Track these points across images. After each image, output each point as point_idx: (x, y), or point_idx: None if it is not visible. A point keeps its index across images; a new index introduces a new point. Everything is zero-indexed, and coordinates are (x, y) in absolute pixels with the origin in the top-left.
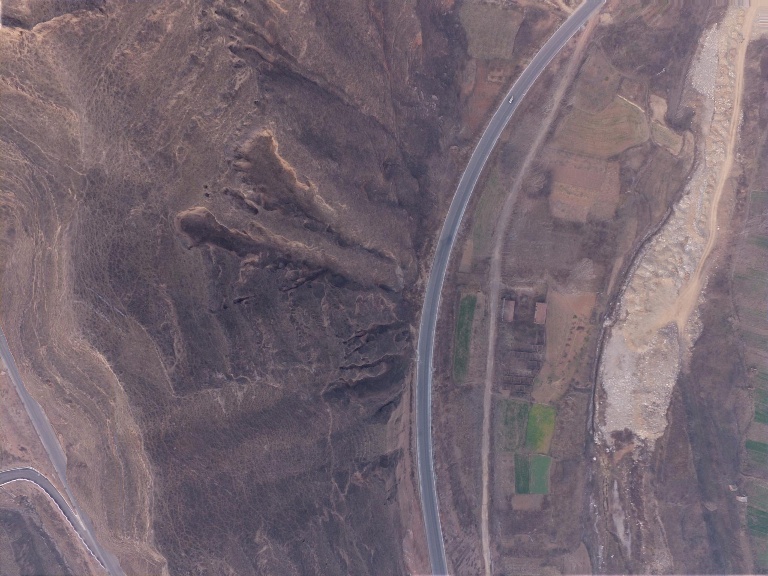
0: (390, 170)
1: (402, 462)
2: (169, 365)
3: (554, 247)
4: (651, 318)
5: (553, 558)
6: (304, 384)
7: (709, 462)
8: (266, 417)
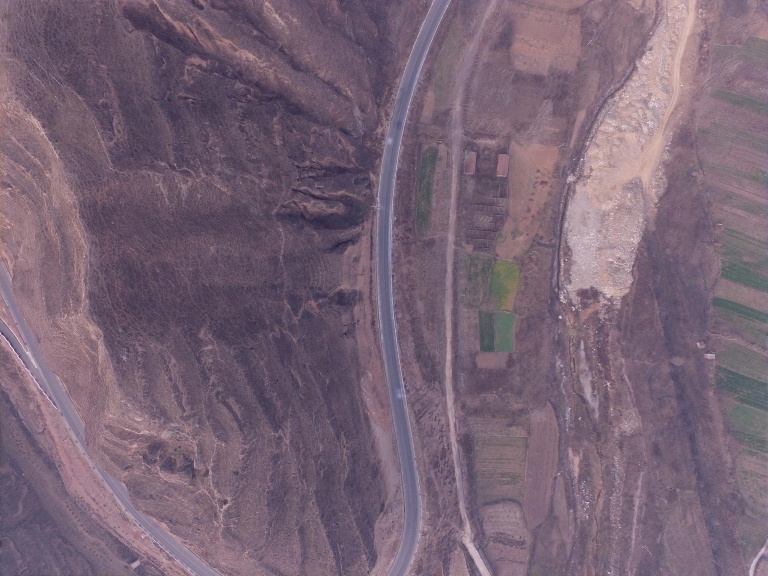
0: (346, 6)
1: (361, 306)
2: (107, 139)
3: (516, 100)
4: (615, 174)
5: (519, 418)
6: (254, 198)
7: (676, 321)
8: (213, 220)
